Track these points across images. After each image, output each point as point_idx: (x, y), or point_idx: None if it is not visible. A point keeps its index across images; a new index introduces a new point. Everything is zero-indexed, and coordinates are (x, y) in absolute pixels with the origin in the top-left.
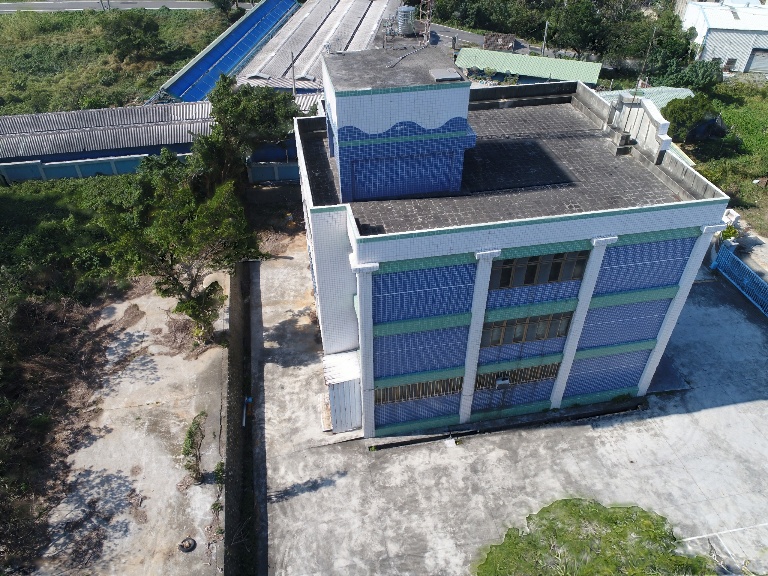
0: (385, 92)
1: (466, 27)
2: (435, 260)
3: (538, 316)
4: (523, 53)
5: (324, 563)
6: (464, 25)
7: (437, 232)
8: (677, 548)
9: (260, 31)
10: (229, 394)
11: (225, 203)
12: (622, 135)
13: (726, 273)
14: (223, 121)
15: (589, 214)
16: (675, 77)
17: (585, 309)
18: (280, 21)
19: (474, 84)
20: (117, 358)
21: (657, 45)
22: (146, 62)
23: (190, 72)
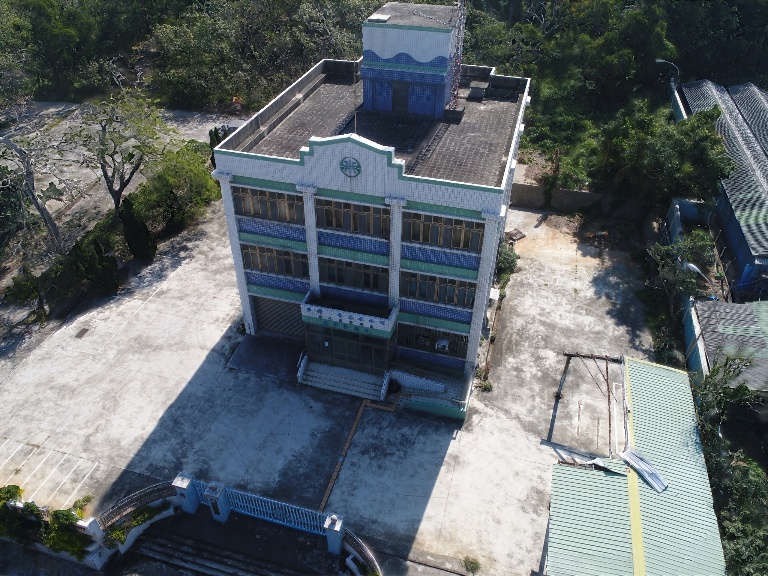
0: None
1: None
2: None
3: None
4: None
5: None
6: None
7: None
8: (160, 283)
9: None
10: None
11: None
12: None
13: None
14: None
15: None
16: None
17: None
18: None
19: None
20: None
21: None
22: None
23: None
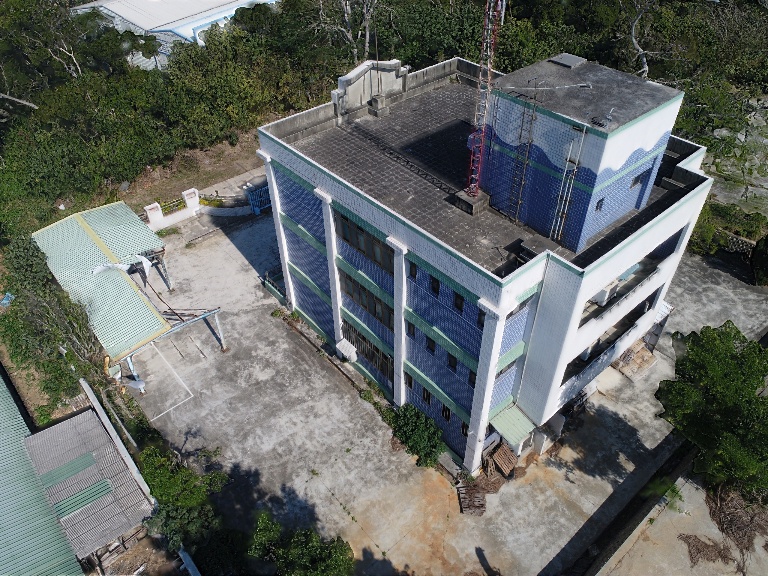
0: None
1: None
2: None
3: None
4: None
5: (726, 313)
6: None
7: None
8: None
9: None
10: None
11: None
12: None
13: (267, 204)
14: None
15: None
16: None
17: None
18: None
19: None
20: None
21: None
22: None
23: None
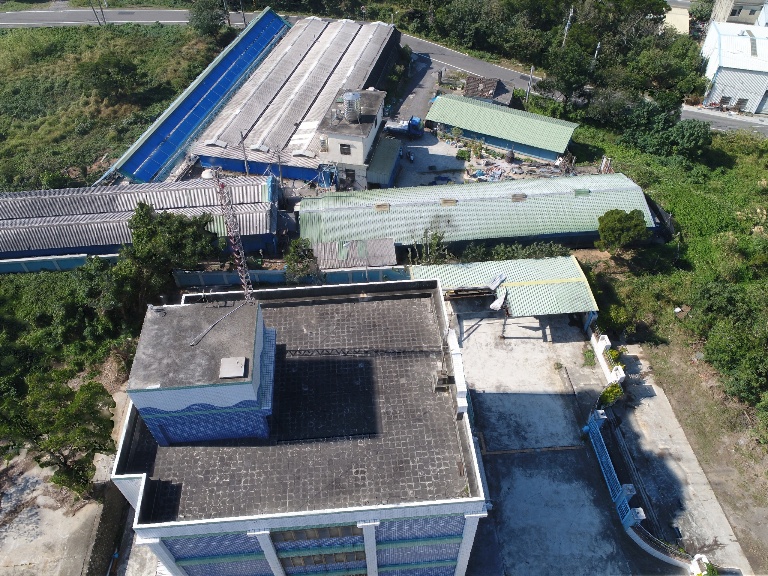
0: (172, 389)
1: (464, 47)
2: (214, 533)
3: (331, 553)
4: (503, 101)
5: None
6: (462, 44)
7: (205, 523)
8: None
9: (236, 71)
10: (92, 558)
11: (83, 406)
12: (438, 378)
13: (593, 441)
14: (132, 259)
15: (346, 511)
16: (660, 136)
17: (373, 551)
18: (262, 53)
19: (440, 145)
20: (9, 508)
21: (648, 96)
22: (123, 105)
23: (148, 142)
